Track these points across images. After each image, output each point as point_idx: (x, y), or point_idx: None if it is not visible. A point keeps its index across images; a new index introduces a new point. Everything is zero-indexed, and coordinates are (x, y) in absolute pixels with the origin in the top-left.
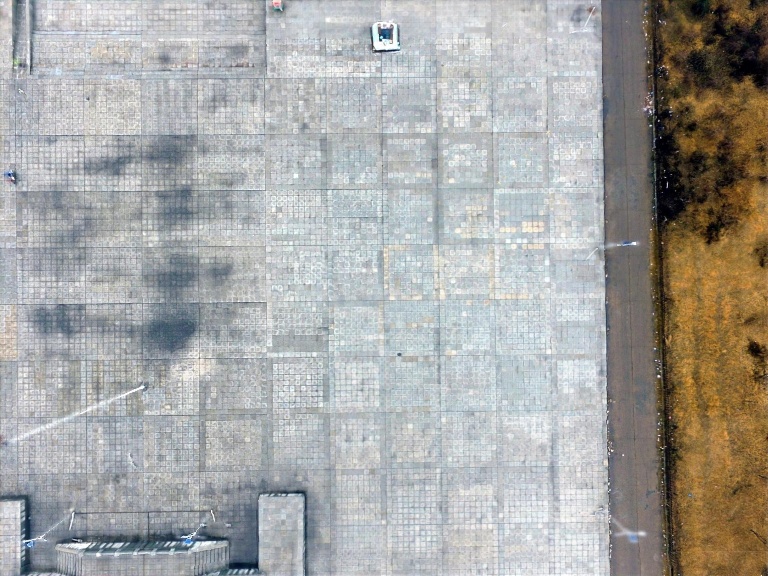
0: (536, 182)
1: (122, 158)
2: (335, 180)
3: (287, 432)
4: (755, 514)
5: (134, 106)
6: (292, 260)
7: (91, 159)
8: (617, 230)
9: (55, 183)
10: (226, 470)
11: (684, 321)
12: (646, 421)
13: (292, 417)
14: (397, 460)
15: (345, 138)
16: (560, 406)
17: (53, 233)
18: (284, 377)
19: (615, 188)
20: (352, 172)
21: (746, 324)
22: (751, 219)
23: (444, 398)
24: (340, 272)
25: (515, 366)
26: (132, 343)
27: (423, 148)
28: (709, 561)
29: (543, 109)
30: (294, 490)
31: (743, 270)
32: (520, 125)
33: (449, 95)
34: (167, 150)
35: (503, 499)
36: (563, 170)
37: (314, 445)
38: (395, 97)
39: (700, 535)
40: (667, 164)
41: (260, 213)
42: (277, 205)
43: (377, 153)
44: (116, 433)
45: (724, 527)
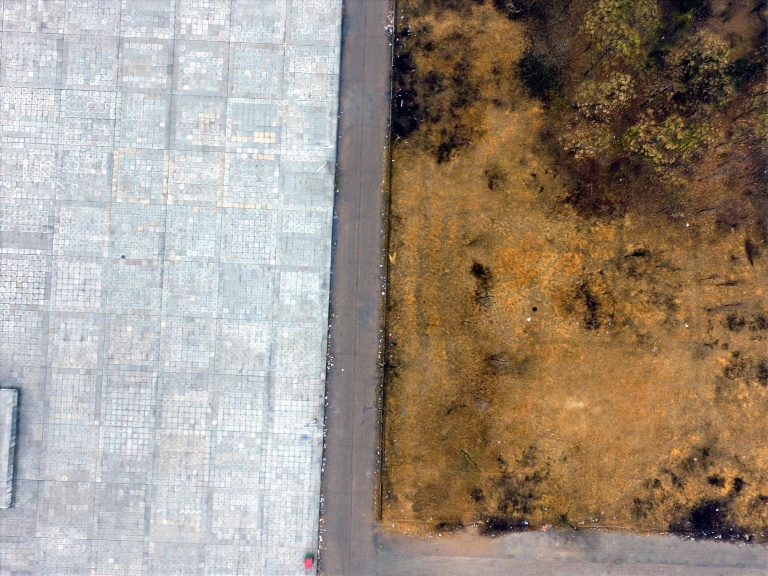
0: (270, 93)
1: None
2: (70, 80)
3: (6, 327)
4: (468, 435)
5: None
6: (22, 157)
7: None
8: (351, 146)
9: None
10: None
11: (410, 239)
12: (368, 337)
13: (12, 313)
14: (114, 362)
15: (82, 39)
16: (281, 317)
17: None
18: (6, 273)
19: (351, 104)
20: (87, 73)
21: (471, 245)
22: (482, 141)
23: (165, 303)
24: (69, 172)
25: (238, 275)
26: None
27: (159, 53)
28: (420, 480)
29: (281, 21)
30: (9, 386)
31: (471, 191)
32: (257, 36)
33: (188, 2)
34: None
35: (218, 406)
36: (298, 83)
37: (32, 342)
38: (134, 1)
39: (412, 453)
40: (403, 83)
41: None
42: (10, 102)
43: (113, 56)
44: None
45: (436, 446)
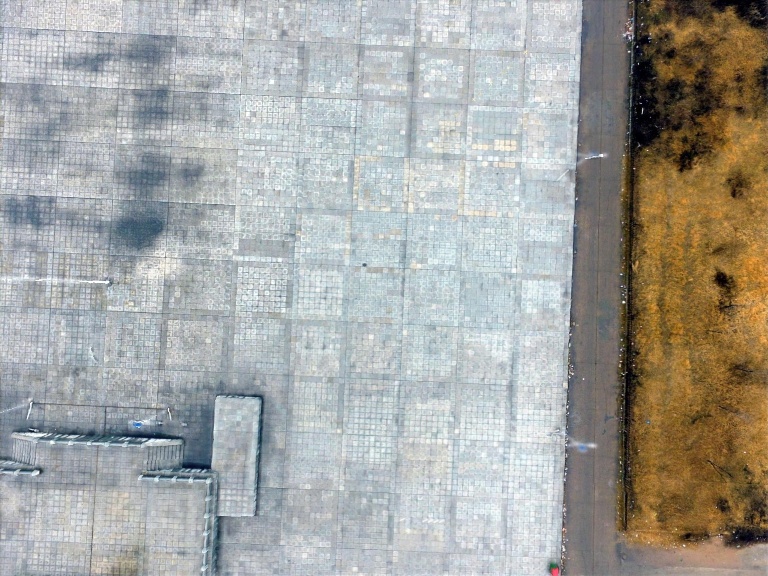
0: (511, 101)
1: (101, 55)
2: (310, 88)
3: (248, 335)
4: (713, 445)
5: (116, 4)
6: (263, 165)
7: (70, 54)
8: (590, 154)
9: (34, 76)
10: (185, 370)
11: (652, 248)
12: (608, 346)
13: (254, 321)
14: (356, 370)
15: (323, 47)
16: (522, 326)
17: (29, 125)
18: (248, 281)
19: (590, 112)
20: (328, 81)
21: (714, 254)
22: (725, 149)
23: (407, 311)
24: (310, 179)
25: (479, 283)
26: (100, 238)
27: (400, 61)
28: (664, 490)
29: (522, 29)
30: (252, 393)
31: (714, 200)
32: (498, 43)
33: (429, 10)
34: (146, 49)
35: (460, 415)
36: (538, 90)
37: (274, 350)
38: (375, 9)
39: (656, 463)
40: (643, 90)
41: (234, 117)
42: (251, 110)
43: (354, 64)
44: (79, 326)
45: (681, 456)
